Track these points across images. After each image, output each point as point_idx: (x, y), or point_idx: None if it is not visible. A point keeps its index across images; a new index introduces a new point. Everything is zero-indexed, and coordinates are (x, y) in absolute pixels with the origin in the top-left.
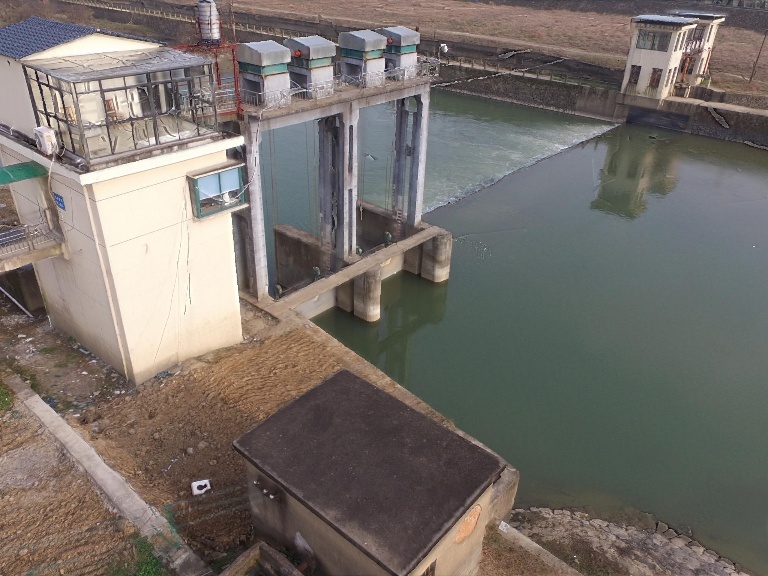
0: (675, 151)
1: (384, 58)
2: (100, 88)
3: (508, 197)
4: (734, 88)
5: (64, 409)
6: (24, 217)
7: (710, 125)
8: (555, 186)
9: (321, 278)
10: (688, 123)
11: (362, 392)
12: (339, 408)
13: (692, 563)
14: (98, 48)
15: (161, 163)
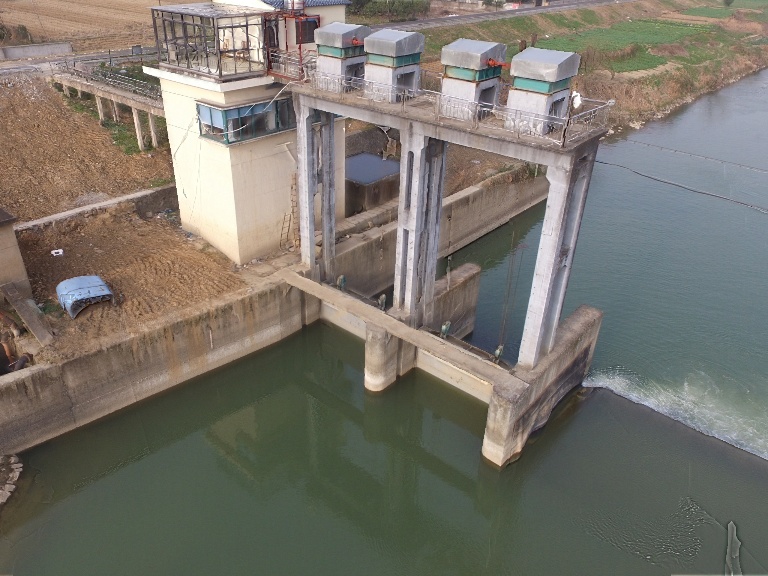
0: None
1: (476, 83)
2: None
3: None
4: None
5: (169, 214)
6: None
7: None
8: None
9: (383, 310)
10: None
11: None
12: None
13: None
14: (245, 2)
15: None
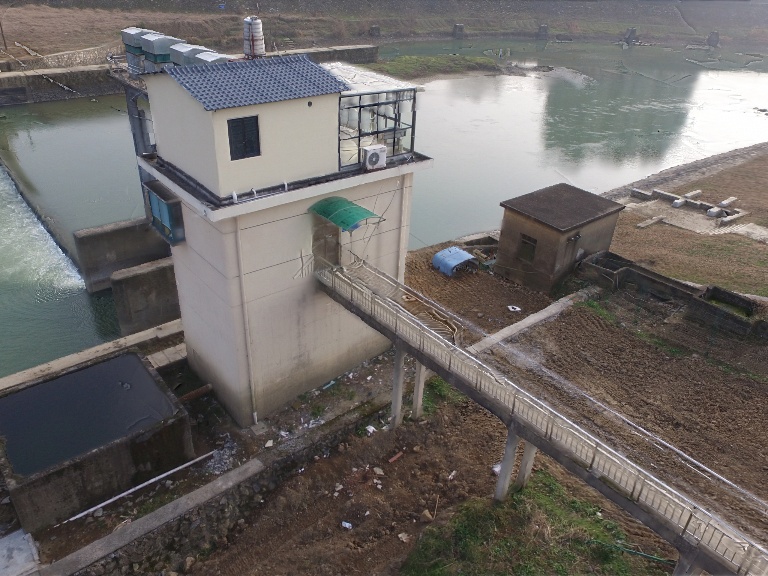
0: (60, 118)
1: None
2: None
3: (64, 196)
4: (7, 57)
5: None
6: (252, 301)
7: (47, 90)
8: (66, 173)
9: None
10: (27, 94)
11: (521, 200)
12: (534, 206)
13: (498, 236)
14: None
15: None
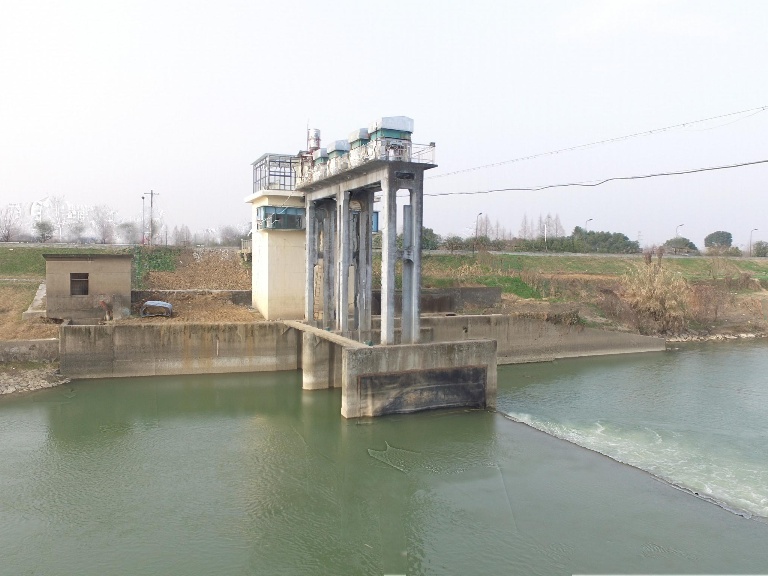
0: None
1: None
2: None
3: None
4: None
5: None
6: None
7: None
8: None
9: None
10: None
11: None
12: None
13: None
14: None
15: None
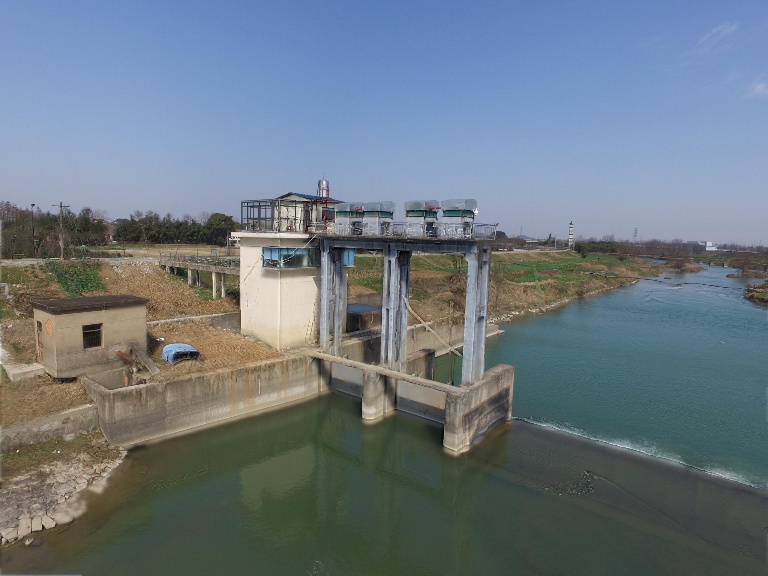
0: None
1: (424, 217)
2: (247, 205)
3: None
4: None
5: None
6: None
7: None
8: None
9: None
10: None
11: None
12: (123, 298)
13: None
14: None
15: (251, 236)
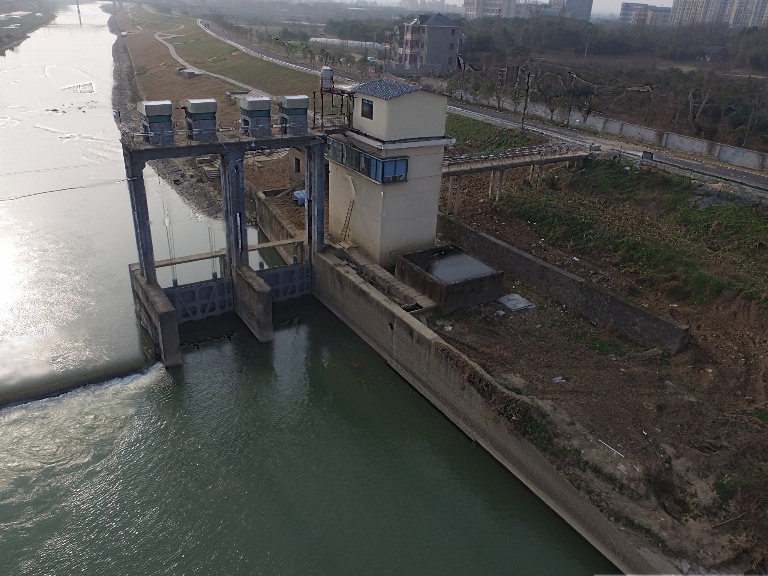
0: None
1: None
2: None
3: None
4: None
5: None
6: None
7: None
8: None
9: None
10: None
11: None
12: None
13: None
14: None
15: None
